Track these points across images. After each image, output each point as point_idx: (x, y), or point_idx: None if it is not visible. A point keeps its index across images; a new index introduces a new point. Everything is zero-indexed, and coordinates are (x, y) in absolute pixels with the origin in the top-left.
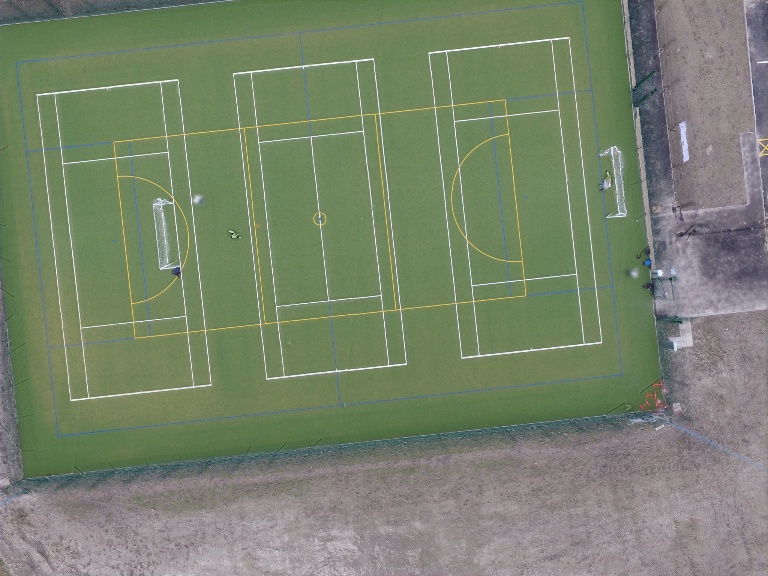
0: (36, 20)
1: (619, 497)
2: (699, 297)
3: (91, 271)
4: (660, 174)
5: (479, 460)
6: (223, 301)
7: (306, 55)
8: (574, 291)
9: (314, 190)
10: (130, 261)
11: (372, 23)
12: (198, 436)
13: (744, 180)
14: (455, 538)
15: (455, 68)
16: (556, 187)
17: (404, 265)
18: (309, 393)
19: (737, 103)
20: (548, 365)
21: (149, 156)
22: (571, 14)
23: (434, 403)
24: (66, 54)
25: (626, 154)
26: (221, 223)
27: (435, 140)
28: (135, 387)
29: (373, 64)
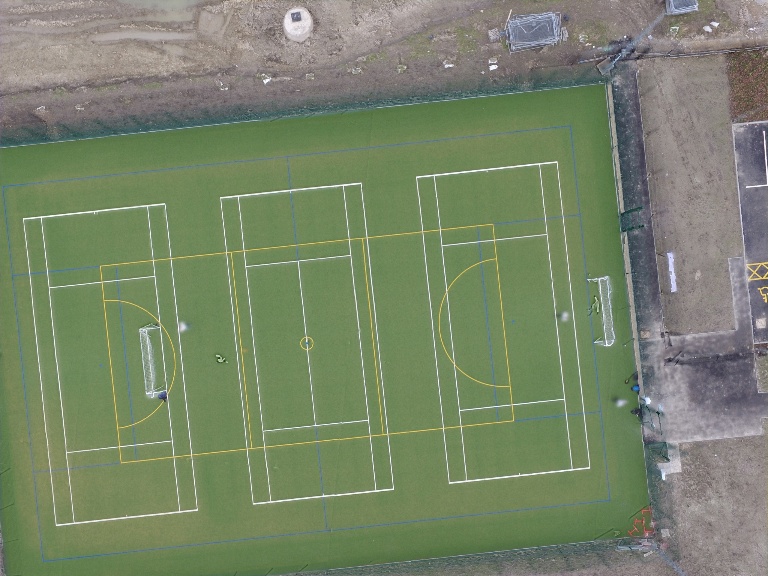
0: (23, 144)
1: None
2: (687, 423)
3: (77, 395)
4: (648, 299)
5: None
6: (209, 426)
7: (293, 179)
8: (562, 416)
9: (301, 314)
10: (116, 385)
11: (360, 147)
12: (184, 561)
13: (733, 305)
14: None
15: (443, 192)
16: (544, 312)
17: (391, 390)
18: (296, 518)
19: (726, 228)
20: (536, 490)
21: (136, 280)
22: (559, 138)
23: (421, 528)
24: (53, 178)
25: (614, 279)
26: (208, 347)
27: (423, 264)
28: (121, 512)
29: (360, 188)
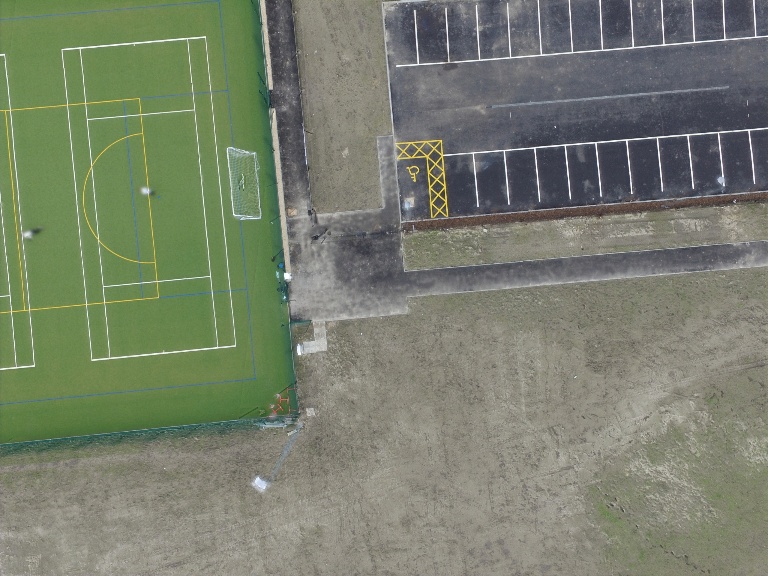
0: None
1: (247, 503)
2: (334, 301)
3: None
4: (296, 176)
5: (107, 465)
6: None
7: None
8: (207, 293)
9: None
10: None
11: (3, 18)
12: None
13: (380, 184)
14: (77, 544)
15: (89, 65)
16: (191, 188)
17: (33, 265)
18: None
19: (374, 106)
20: (180, 368)
21: None
22: (208, 13)
23: (62, 406)
24: None
25: (262, 155)
26: None
27: (67, 138)
28: None
29: (4, 60)
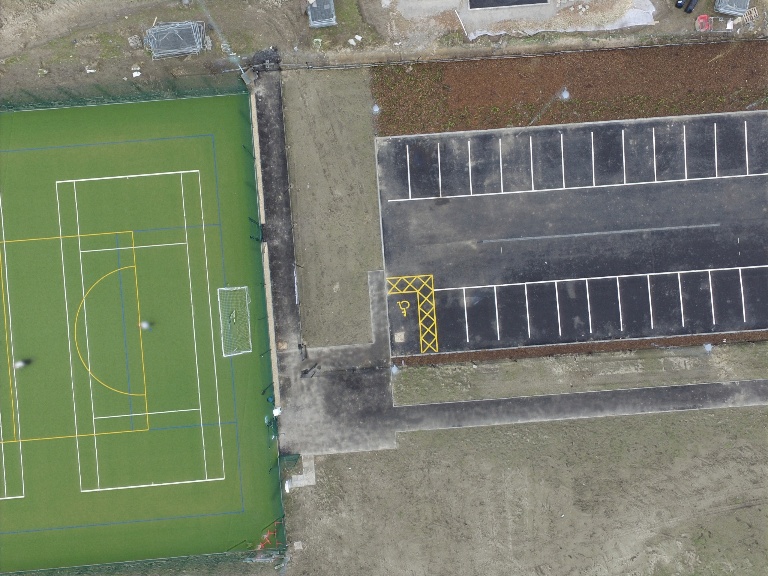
0: None
1: None
2: (322, 435)
3: None
4: (287, 310)
5: None
6: None
7: None
8: (197, 426)
9: None
10: None
11: None
12: None
13: (370, 319)
14: None
15: (82, 198)
16: (182, 320)
17: (25, 396)
18: None
19: (365, 241)
20: (169, 500)
21: None
22: (201, 147)
23: (51, 537)
24: None
25: (253, 289)
26: None
27: (60, 270)
28: None
29: None
